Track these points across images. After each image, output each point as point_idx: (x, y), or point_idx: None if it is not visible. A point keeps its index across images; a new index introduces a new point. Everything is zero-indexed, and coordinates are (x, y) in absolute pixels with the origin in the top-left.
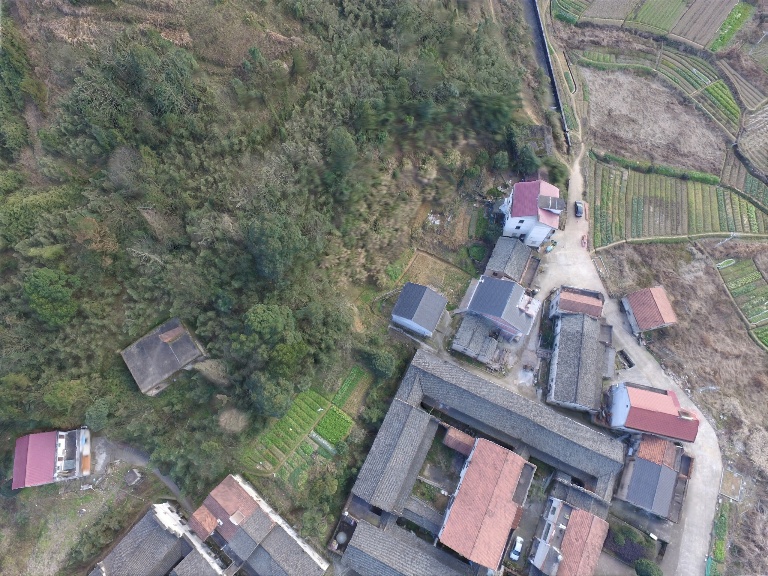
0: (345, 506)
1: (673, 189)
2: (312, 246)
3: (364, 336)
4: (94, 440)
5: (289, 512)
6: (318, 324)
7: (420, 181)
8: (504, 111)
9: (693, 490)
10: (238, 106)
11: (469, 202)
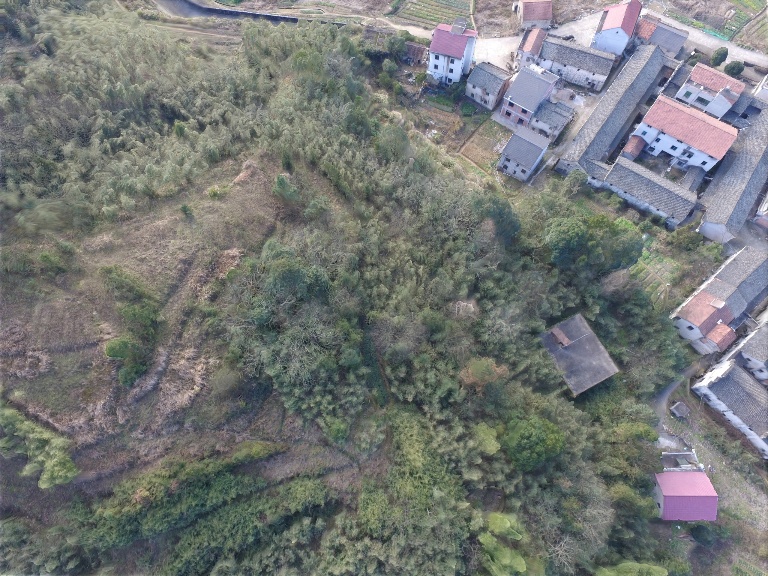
0: None
1: None
2: None
3: None
4: None
5: None
6: None
7: None
8: (352, 44)
9: None
10: (325, 225)
11: (418, 105)
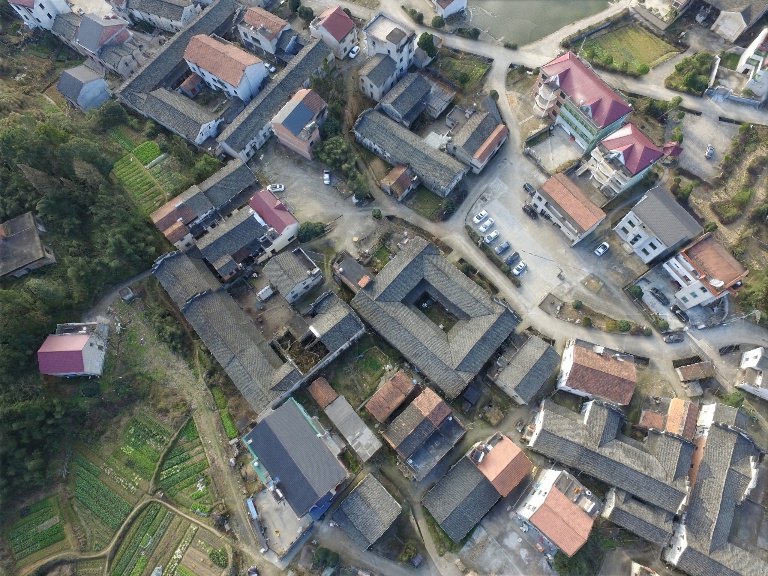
0: (206, 151)
1: None
2: None
3: None
4: None
5: None
6: None
7: None
8: None
9: None
10: None
11: (19, 53)
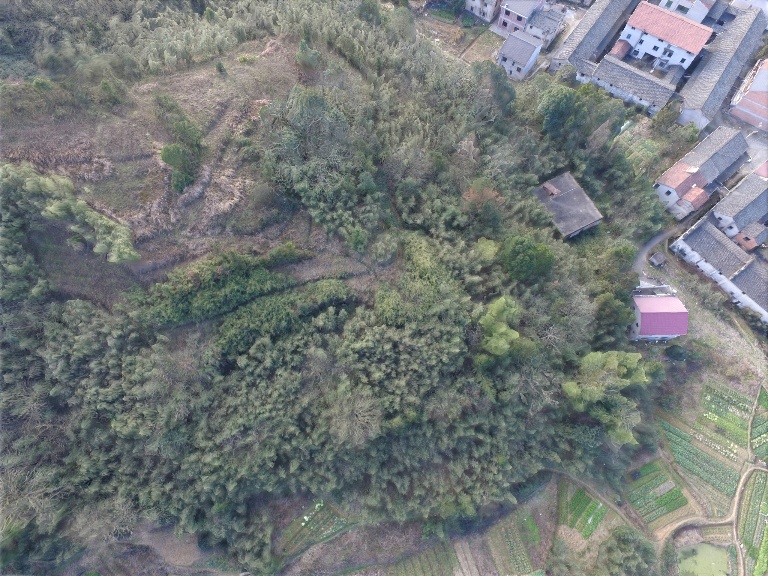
0: None
1: None
2: None
3: None
4: None
5: None
6: None
7: None
8: None
9: None
10: None
11: (422, 18)
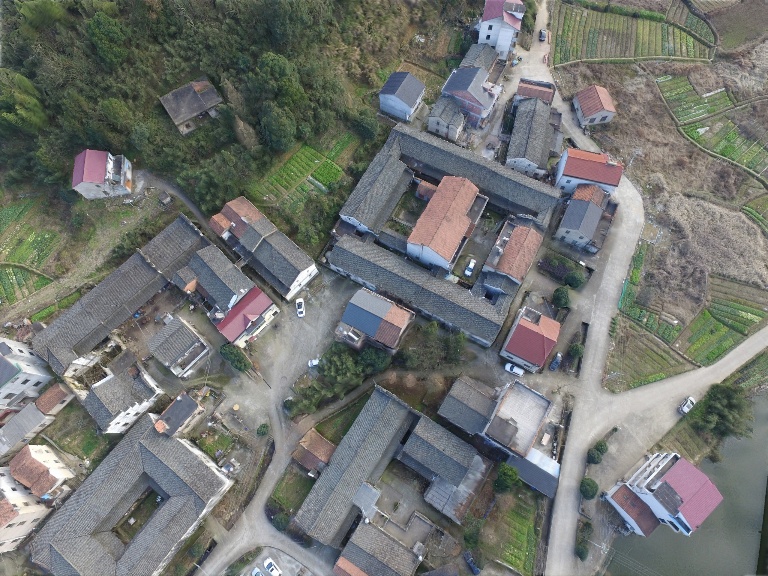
0: (333, 228)
1: (625, 24)
2: (316, 28)
3: (355, 110)
4: (135, 172)
5: (288, 235)
6: (318, 88)
7: (409, 2)
8: None
9: (618, 235)
10: None
11: (450, 27)
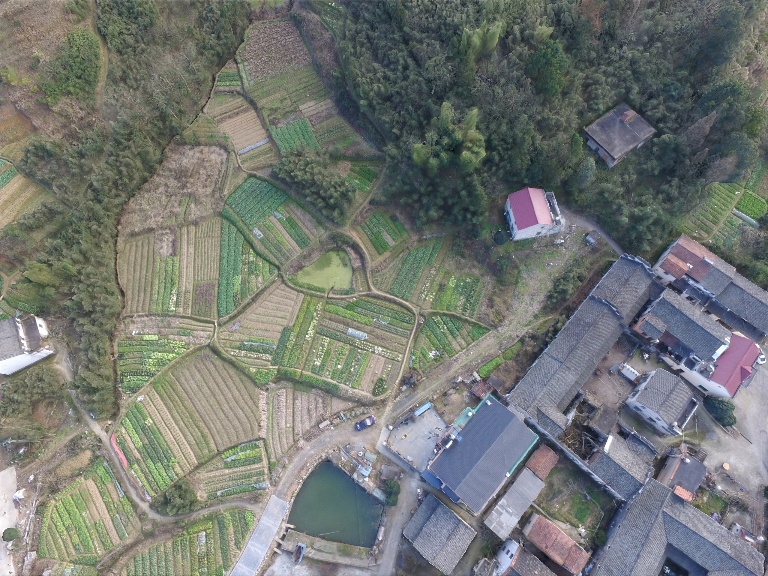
0: None
1: None
2: None
3: None
4: None
5: None
6: None
7: None
8: None
9: None
10: None
11: None
